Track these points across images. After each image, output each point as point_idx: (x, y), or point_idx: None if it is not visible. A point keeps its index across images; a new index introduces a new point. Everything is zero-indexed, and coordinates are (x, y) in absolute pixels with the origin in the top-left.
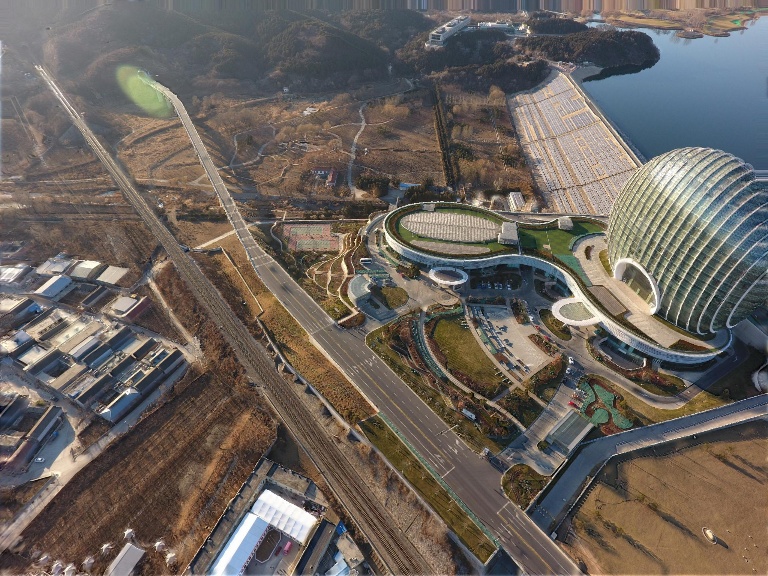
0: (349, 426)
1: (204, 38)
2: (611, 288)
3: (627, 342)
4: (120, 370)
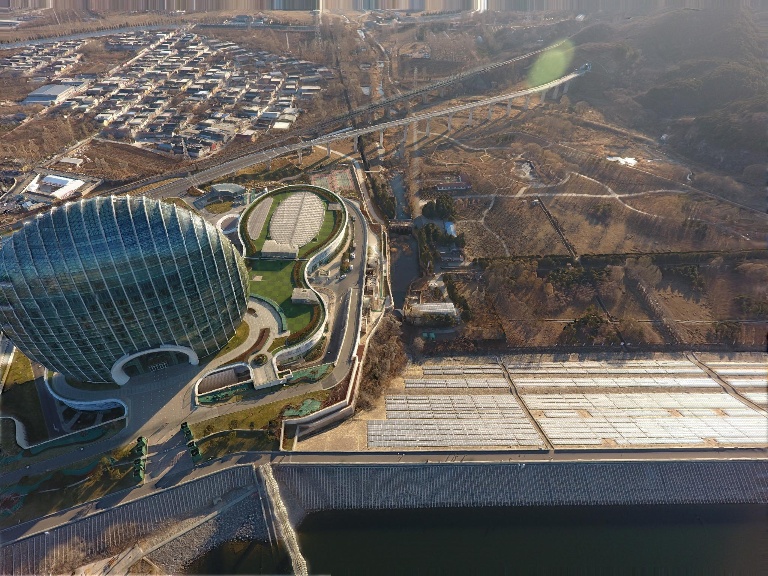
0: (102, 195)
1: (707, 63)
2: None
3: None
4: (192, 141)
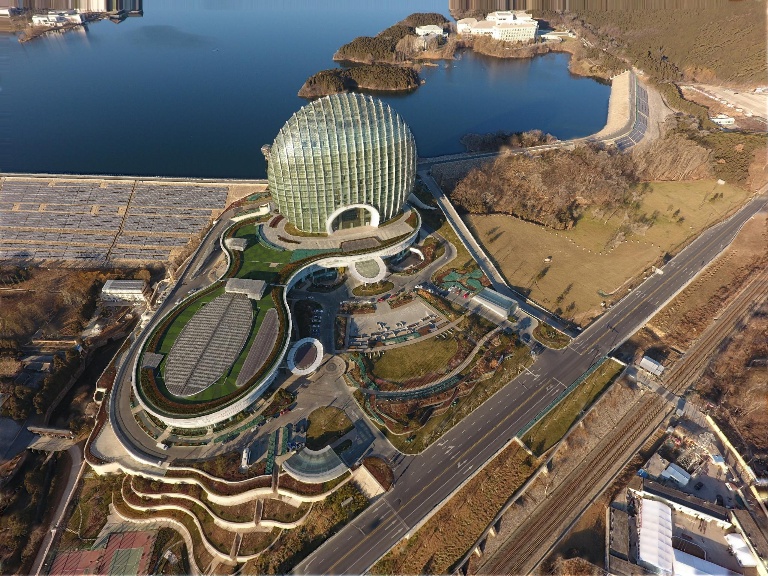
0: None
1: None
2: (344, 239)
3: (401, 250)
4: None
